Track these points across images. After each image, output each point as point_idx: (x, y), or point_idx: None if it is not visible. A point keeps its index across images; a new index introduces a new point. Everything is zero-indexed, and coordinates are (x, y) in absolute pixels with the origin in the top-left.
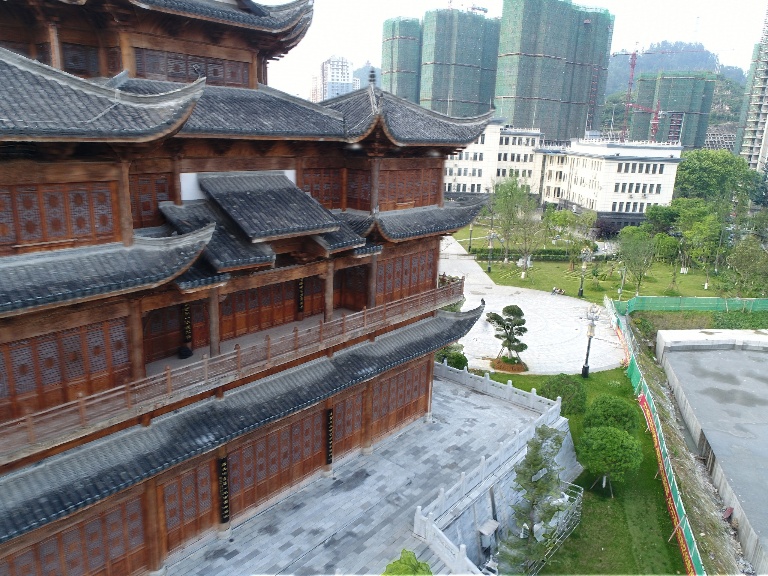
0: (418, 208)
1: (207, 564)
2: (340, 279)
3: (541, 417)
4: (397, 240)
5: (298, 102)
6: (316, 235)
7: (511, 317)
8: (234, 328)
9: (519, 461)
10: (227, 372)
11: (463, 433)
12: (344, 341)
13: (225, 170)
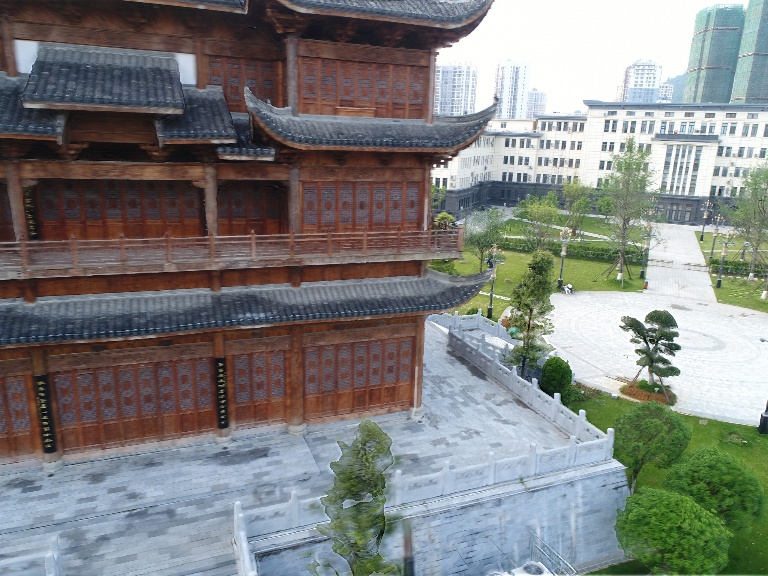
0: (383, 119)
1: (0, 490)
2: (277, 206)
3: (558, 448)
4: (303, 146)
5: None
6: (152, 118)
7: (656, 326)
8: (105, 237)
9: (484, 499)
10: (7, 266)
11: (443, 443)
12: (213, 268)
13: (80, 43)
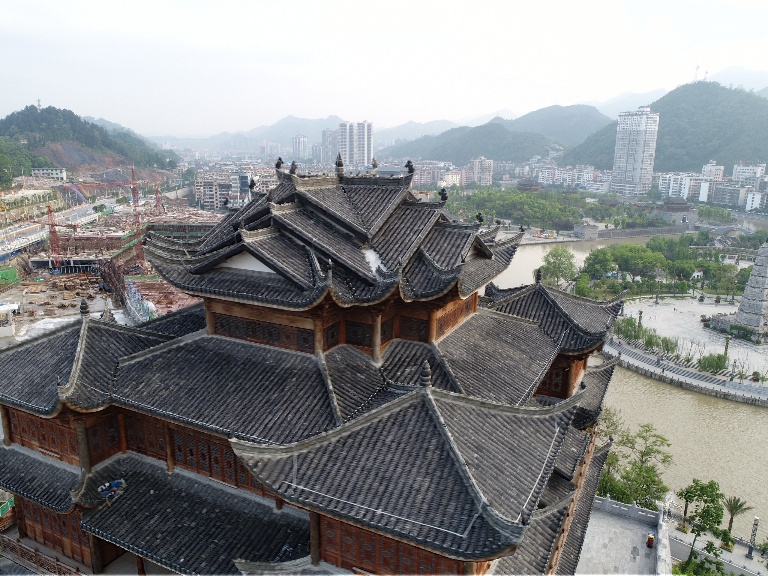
0: None
1: None
2: None
3: None
4: None
5: (170, 317)
6: None
7: None
8: None
9: None
10: None
11: None
12: None
13: None
